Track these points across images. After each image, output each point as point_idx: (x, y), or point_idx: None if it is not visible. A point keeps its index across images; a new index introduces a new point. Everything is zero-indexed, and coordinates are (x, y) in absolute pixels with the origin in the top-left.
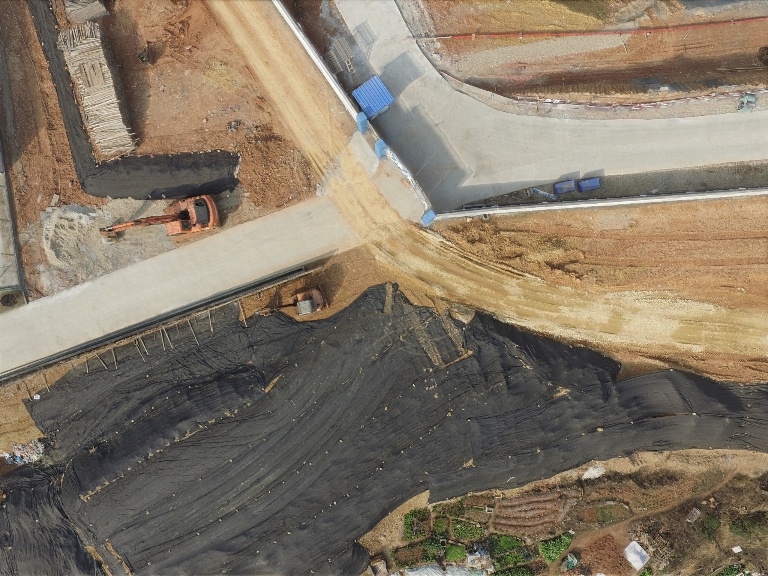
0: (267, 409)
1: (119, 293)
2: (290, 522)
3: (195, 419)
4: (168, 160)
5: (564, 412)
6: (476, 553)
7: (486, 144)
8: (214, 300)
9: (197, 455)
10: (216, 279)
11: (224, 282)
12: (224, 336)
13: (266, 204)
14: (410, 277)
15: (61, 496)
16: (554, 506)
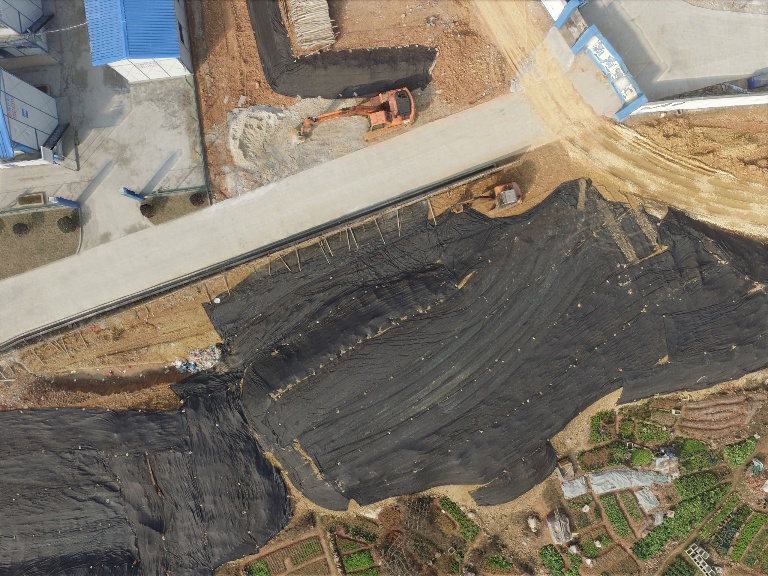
0: (459, 306)
1: (304, 194)
2: (482, 420)
3: (387, 316)
4: (366, 55)
5: (759, 308)
6: (664, 455)
7: (681, 39)
8: (402, 199)
9: (389, 353)
10: (404, 178)
11: (412, 181)
12: (412, 235)
13: (459, 101)
14: (604, 173)
15: (242, 400)
16: (741, 409)
